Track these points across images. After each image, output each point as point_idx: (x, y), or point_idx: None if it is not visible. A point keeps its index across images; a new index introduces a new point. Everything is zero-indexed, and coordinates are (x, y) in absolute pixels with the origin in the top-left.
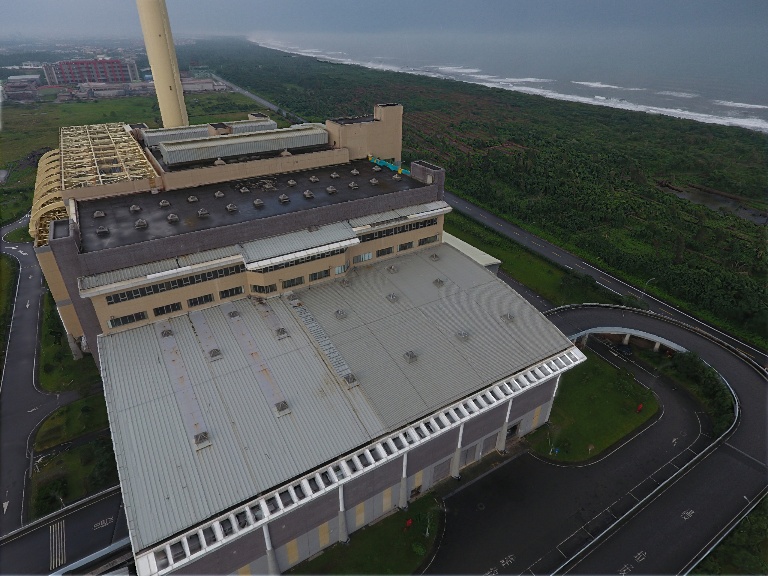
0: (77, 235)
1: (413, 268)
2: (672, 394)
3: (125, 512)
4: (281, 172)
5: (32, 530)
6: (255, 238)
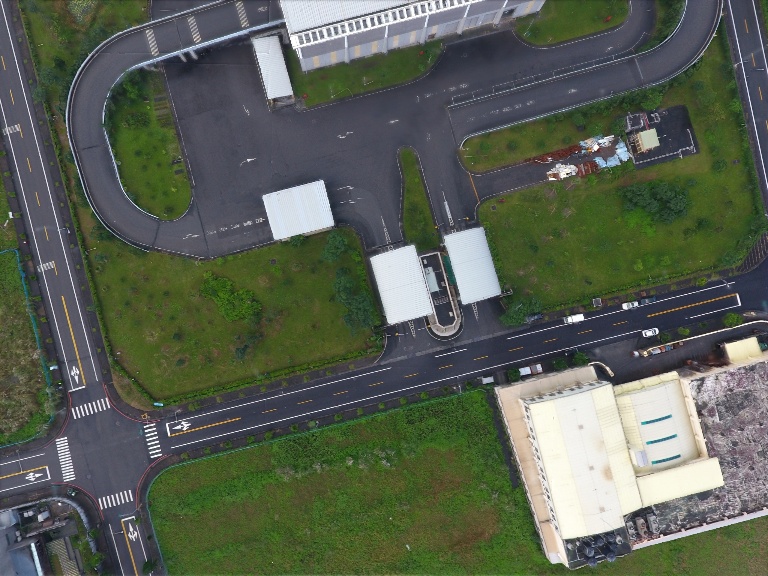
0: None
1: None
2: (643, 14)
3: (283, 12)
4: None
5: (227, 3)
6: None
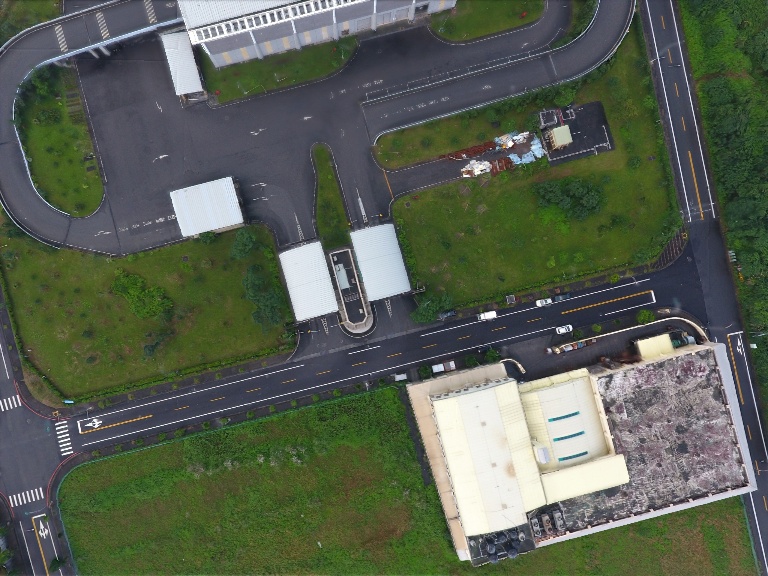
0: None
1: None
2: (559, 10)
3: (180, 8)
4: None
5: None
6: None
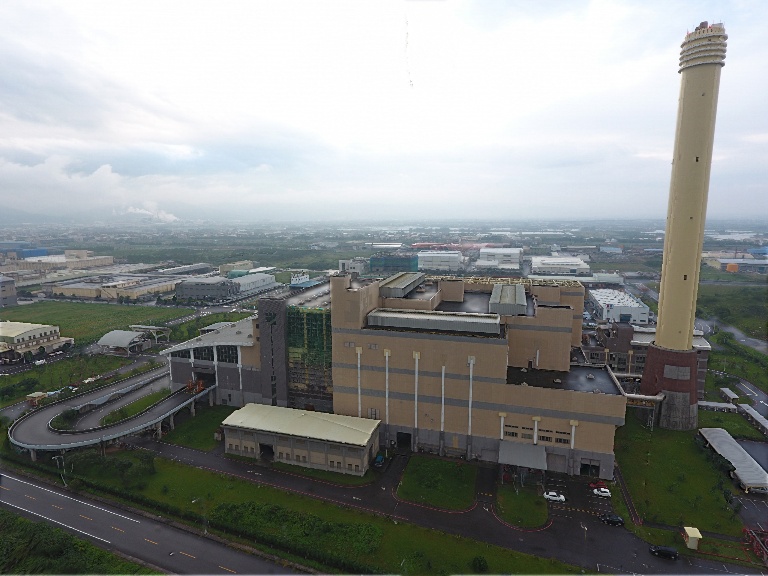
0: None
1: None
2: None
3: None
4: None
5: None
6: None
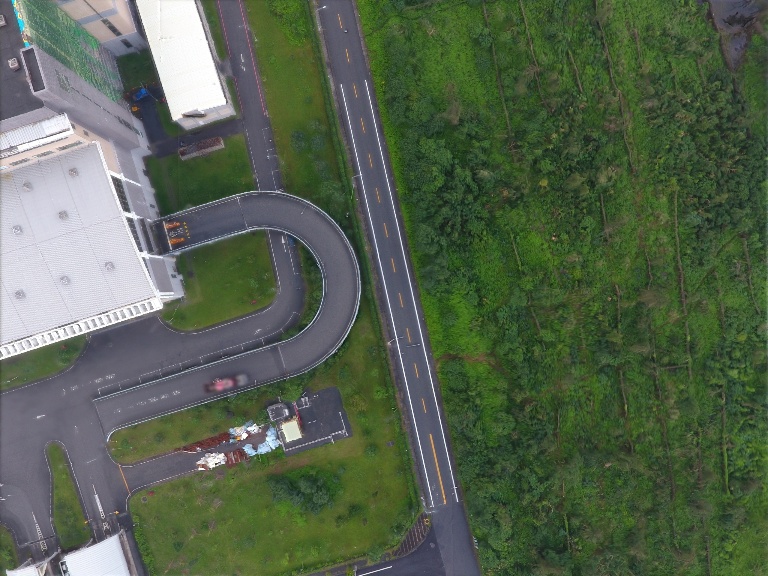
0: None
1: (48, 186)
2: (291, 293)
3: None
4: None
5: None
6: None
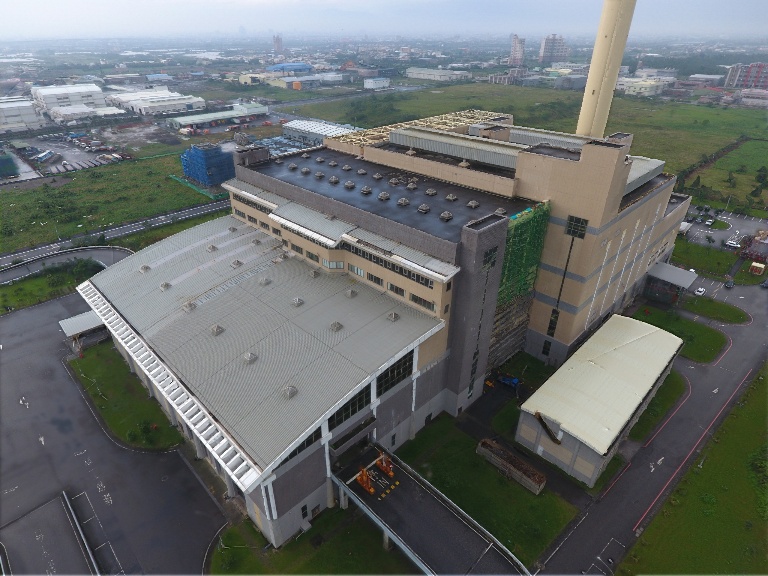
0: (252, 156)
1: (363, 306)
2: None
3: None
4: (439, 178)
5: None
6: (301, 202)
